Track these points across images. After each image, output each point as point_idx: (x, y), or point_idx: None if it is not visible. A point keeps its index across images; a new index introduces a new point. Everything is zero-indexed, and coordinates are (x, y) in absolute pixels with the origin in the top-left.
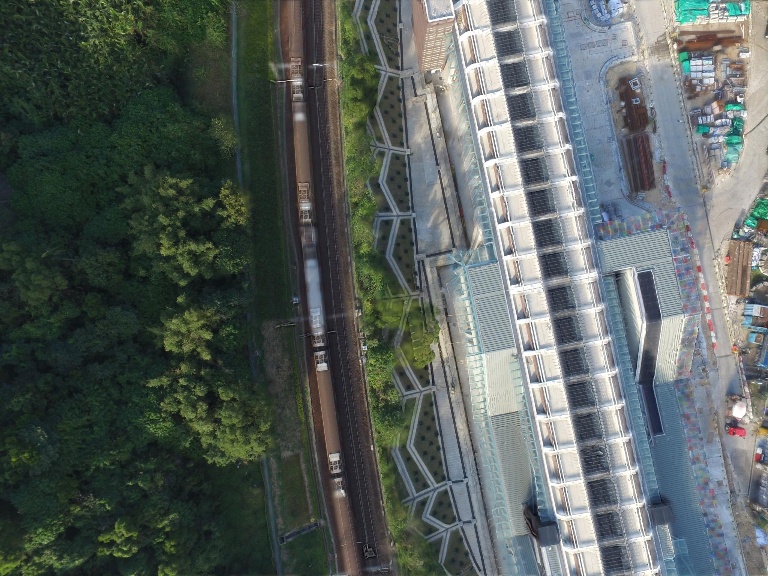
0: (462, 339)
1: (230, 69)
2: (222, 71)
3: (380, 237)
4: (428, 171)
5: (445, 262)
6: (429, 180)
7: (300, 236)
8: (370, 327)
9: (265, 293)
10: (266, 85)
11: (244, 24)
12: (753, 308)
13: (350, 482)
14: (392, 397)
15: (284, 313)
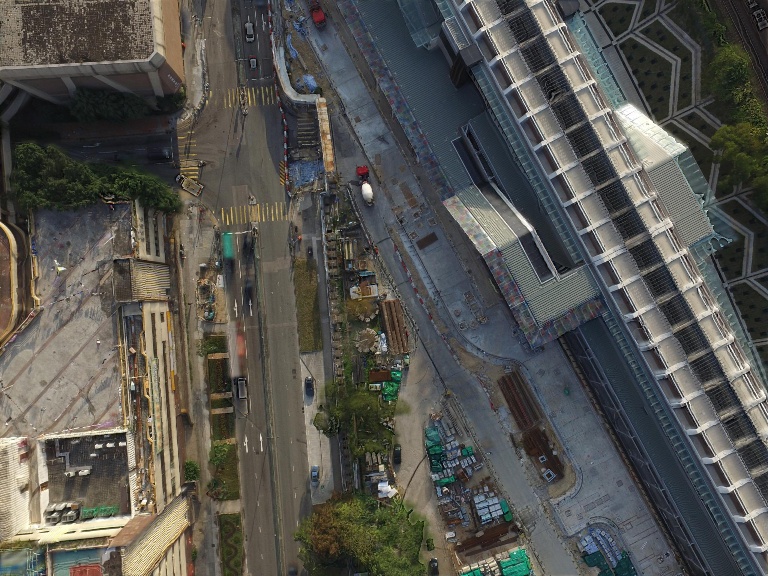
0: None
1: None
2: None
3: (767, 250)
4: None
5: None
6: None
7: None
8: None
9: None
10: None
11: None
12: None
13: (742, 6)
14: (740, 93)
15: None
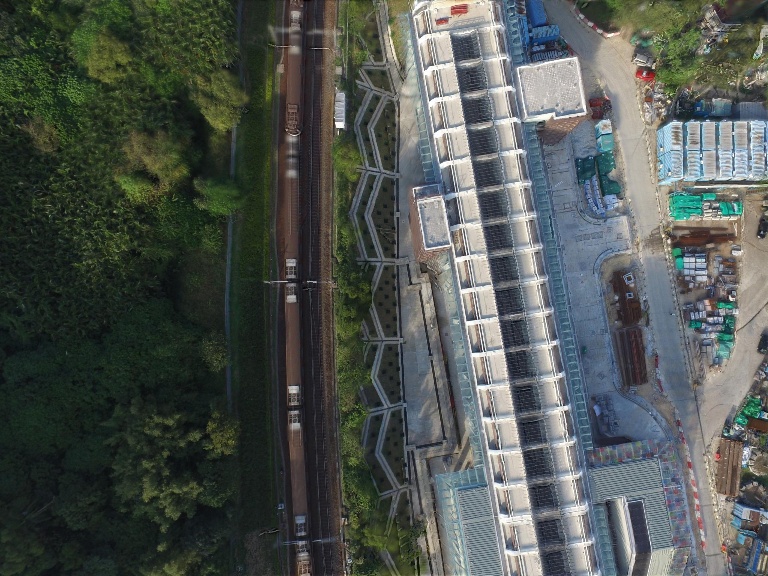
0: (450, 546)
1: (223, 276)
2: (215, 278)
3: (370, 435)
4: (421, 360)
5: (435, 454)
6: (421, 370)
7: (288, 440)
8: (356, 546)
9: (250, 503)
10: (260, 287)
11: (240, 228)
12: (742, 511)
13: None
14: None
15: (268, 519)
